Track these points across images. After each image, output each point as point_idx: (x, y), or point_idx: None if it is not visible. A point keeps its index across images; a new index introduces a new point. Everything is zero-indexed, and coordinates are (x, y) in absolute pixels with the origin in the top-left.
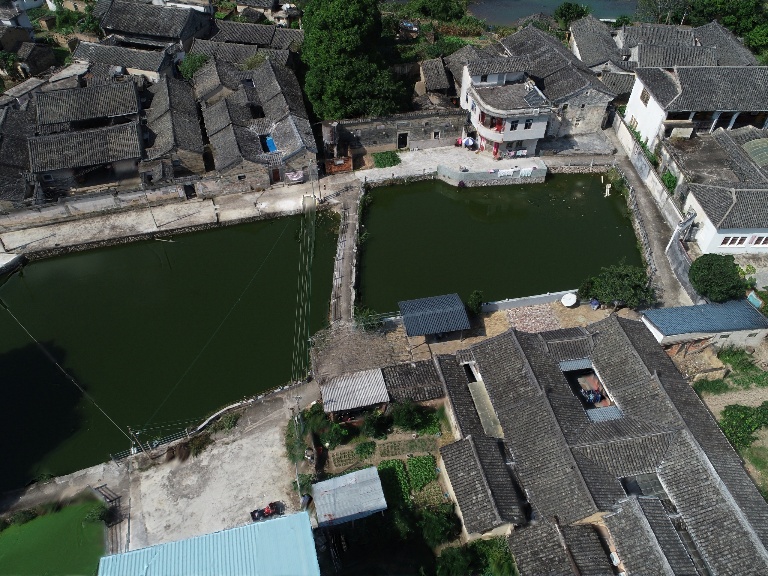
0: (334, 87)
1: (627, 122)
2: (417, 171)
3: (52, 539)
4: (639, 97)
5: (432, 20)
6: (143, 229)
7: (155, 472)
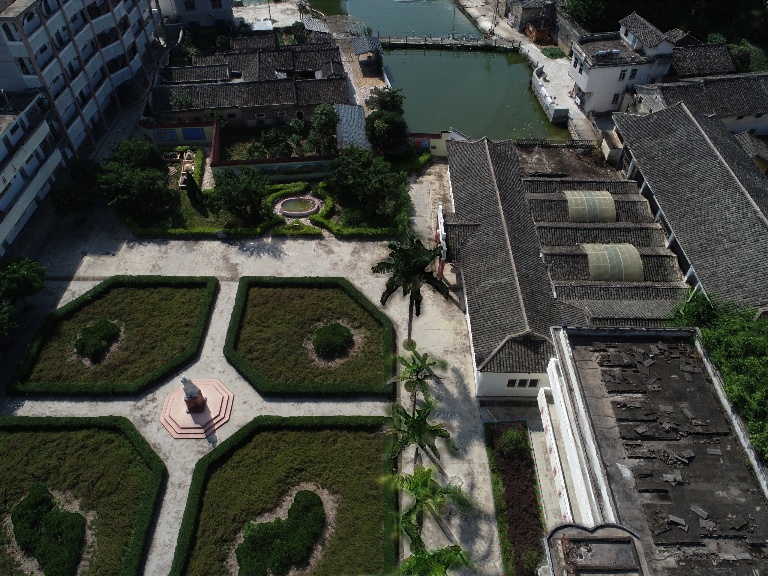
0: None
1: None
2: (541, 64)
3: None
4: None
5: None
6: None
7: (295, 6)
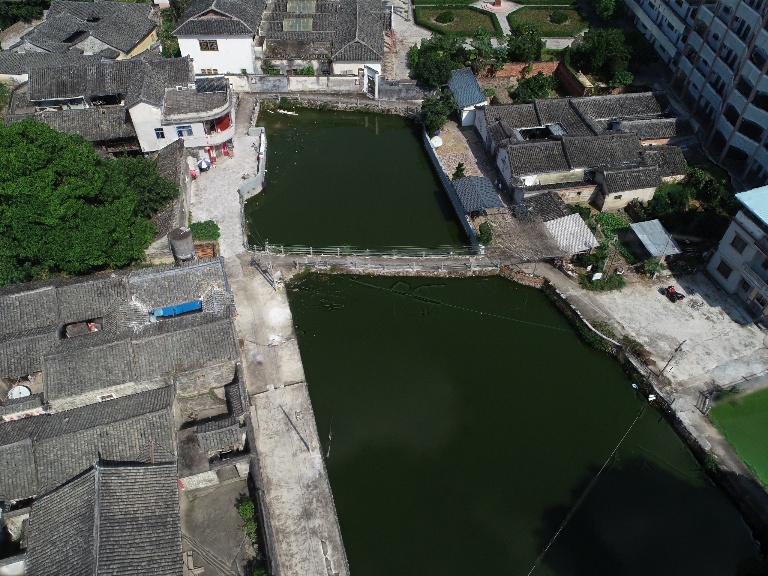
0: (130, 206)
1: None
2: (234, 210)
3: (759, 430)
4: (199, 51)
5: None
6: (314, 470)
7: None
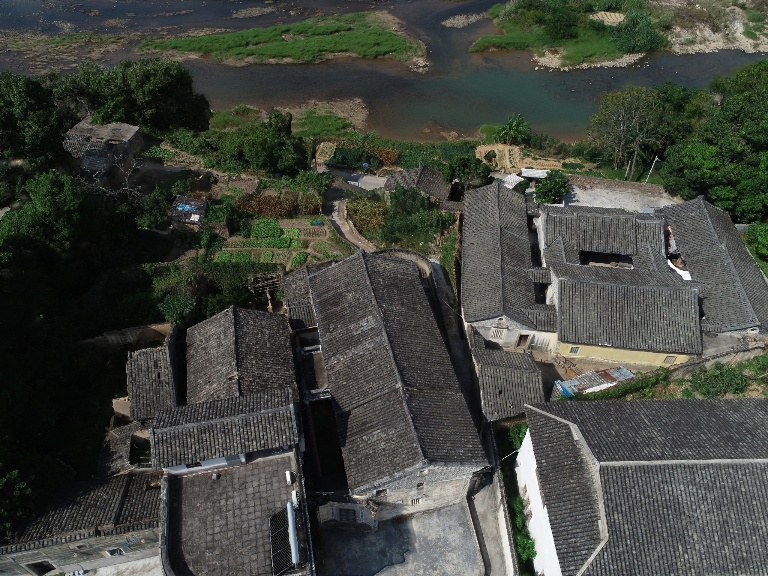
0: None
1: (519, 483)
2: None
3: None
4: (534, 468)
5: (255, 172)
6: None
7: None
